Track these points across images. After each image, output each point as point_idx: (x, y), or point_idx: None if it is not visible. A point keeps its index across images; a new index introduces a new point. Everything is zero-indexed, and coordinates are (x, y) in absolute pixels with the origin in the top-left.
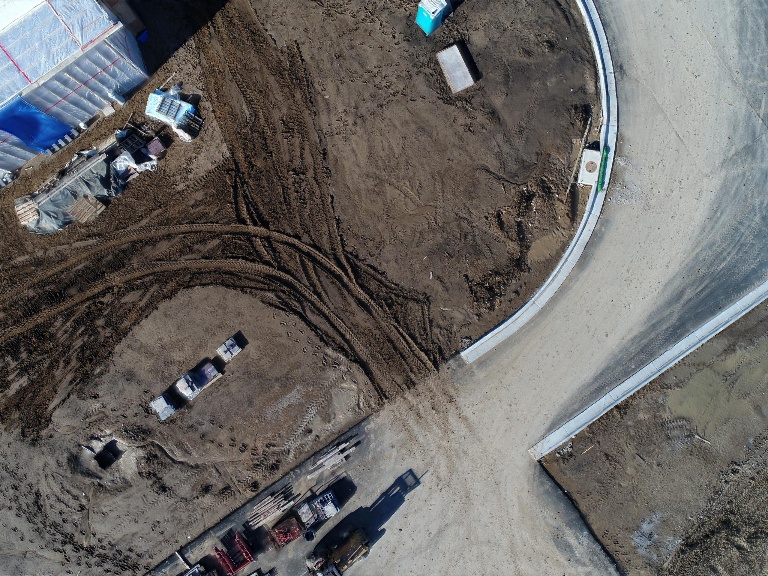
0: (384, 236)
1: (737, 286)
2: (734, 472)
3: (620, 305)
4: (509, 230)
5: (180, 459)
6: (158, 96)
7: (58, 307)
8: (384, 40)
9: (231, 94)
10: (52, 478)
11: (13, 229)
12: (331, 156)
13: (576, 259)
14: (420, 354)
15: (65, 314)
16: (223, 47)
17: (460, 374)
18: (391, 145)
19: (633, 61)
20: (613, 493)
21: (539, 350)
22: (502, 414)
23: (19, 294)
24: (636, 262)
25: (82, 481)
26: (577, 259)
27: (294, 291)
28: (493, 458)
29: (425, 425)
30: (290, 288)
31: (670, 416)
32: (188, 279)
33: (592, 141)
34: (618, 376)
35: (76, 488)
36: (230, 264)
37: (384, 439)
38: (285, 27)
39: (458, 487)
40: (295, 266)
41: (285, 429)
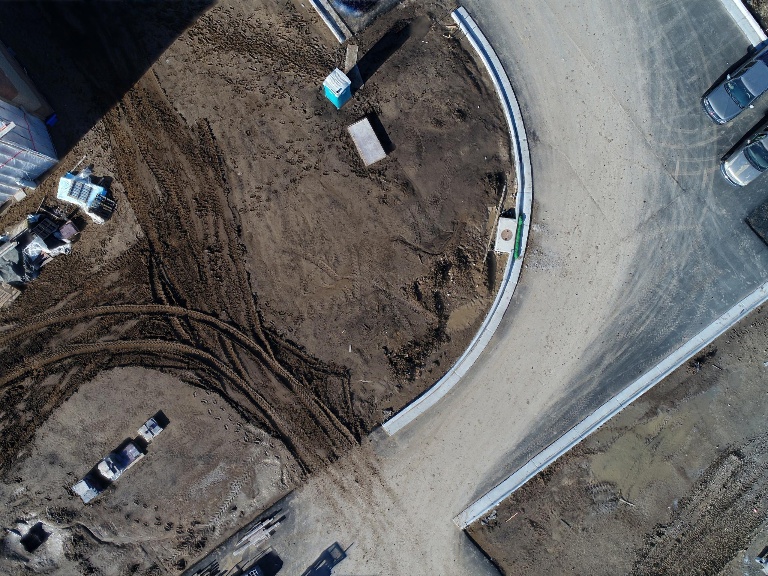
0: (302, 311)
1: (657, 349)
2: (659, 534)
3: (540, 372)
4: (427, 301)
5: (106, 539)
6: (69, 180)
7: None
8: (295, 115)
9: (143, 175)
10: None
11: None
12: (246, 233)
13: (495, 327)
14: (342, 427)
15: None
16: (133, 128)
17: (382, 446)
18: (306, 220)
19: (546, 127)
20: (539, 559)
21: (461, 419)
22: (425, 484)
23: None
24: (555, 328)
25: (9, 564)
26: (496, 327)
27: (213, 369)
28: (418, 528)
29: (349, 498)
30: (209, 366)
31: (594, 480)
32: (107, 361)
33: (508, 208)
34: (540, 443)
35: (3, 572)
36: (149, 344)
37: (308, 513)
38: (195, 106)
39: (384, 558)
40: (214, 344)
41: (209, 506)
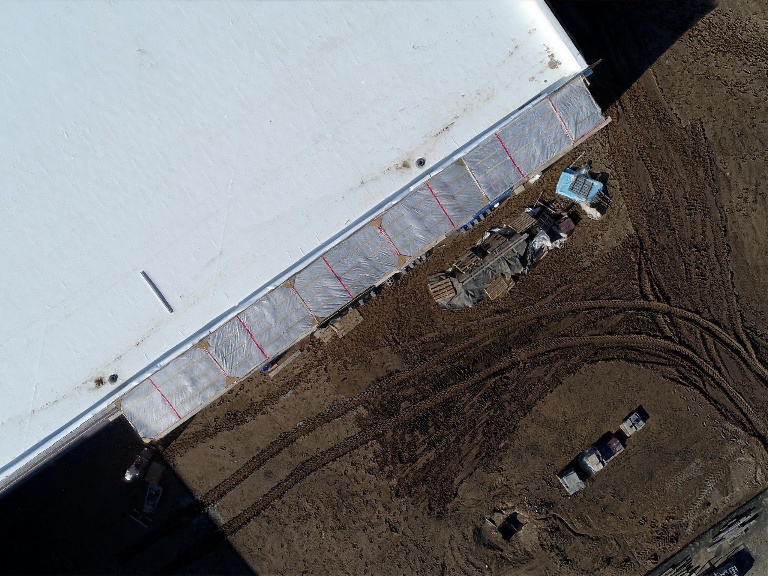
0: None
1: None
2: None
3: None
4: None
5: (580, 531)
6: (571, 175)
7: (465, 382)
8: None
9: (638, 172)
10: (458, 551)
11: (425, 306)
12: (731, 233)
13: None
14: None
15: (472, 389)
16: (631, 126)
17: None
18: None
19: None
20: None
21: None
22: None
23: (428, 370)
24: None
25: (485, 553)
26: None
27: (695, 366)
28: None
29: None
30: (691, 363)
31: None
32: (593, 355)
33: None
34: None
35: (480, 560)
36: (632, 339)
37: None
38: (690, 106)
39: None
40: (695, 341)
41: (684, 502)
